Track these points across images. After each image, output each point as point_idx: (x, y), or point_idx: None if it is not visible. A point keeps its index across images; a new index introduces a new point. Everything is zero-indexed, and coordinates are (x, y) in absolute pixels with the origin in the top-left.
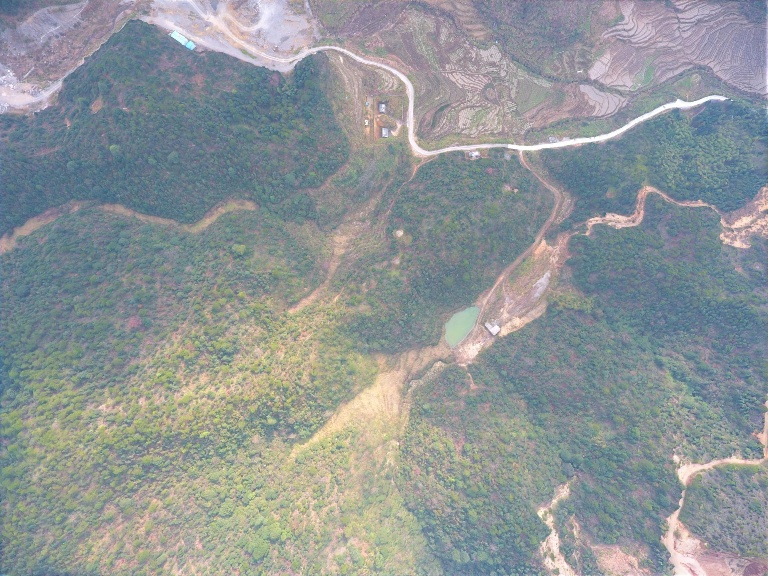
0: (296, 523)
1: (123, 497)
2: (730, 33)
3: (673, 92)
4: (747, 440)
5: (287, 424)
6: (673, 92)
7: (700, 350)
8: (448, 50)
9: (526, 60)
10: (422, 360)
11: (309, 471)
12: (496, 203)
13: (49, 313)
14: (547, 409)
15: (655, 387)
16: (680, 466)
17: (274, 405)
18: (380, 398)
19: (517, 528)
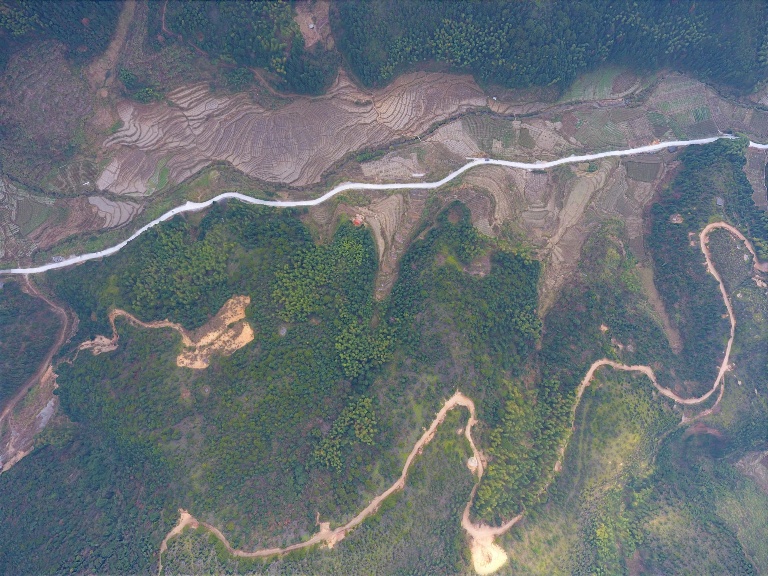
0: None
1: None
2: (247, 124)
3: (182, 195)
4: None
5: None
6: (182, 195)
7: (135, 488)
8: None
9: (23, 180)
10: None
11: None
12: None
13: None
14: (7, 559)
15: (78, 536)
16: None
17: None
18: None
19: None
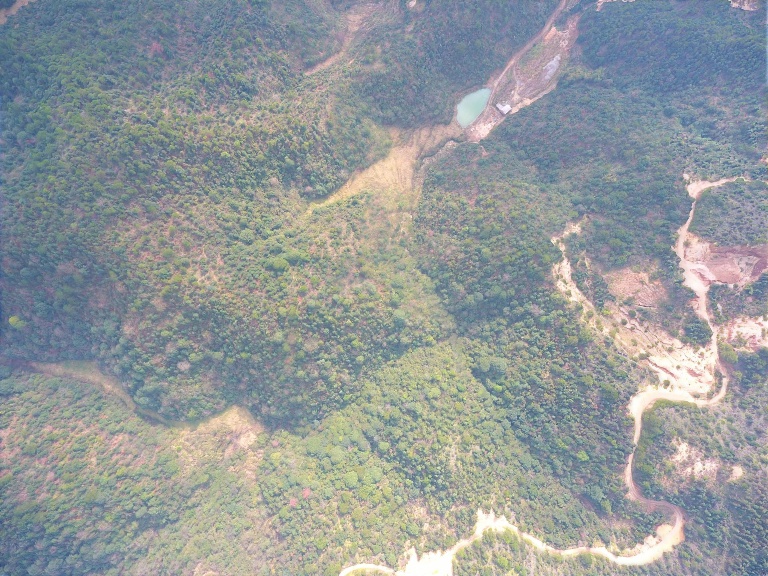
0: (314, 249)
1: (148, 200)
2: None
3: None
4: (755, 165)
5: (304, 173)
6: None
7: (709, 98)
8: None
9: None
10: (434, 138)
11: (326, 218)
12: None
13: (74, 34)
14: (558, 165)
15: (665, 128)
16: (690, 183)
17: (292, 143)
18: (394, 171)
19: (530, 250)
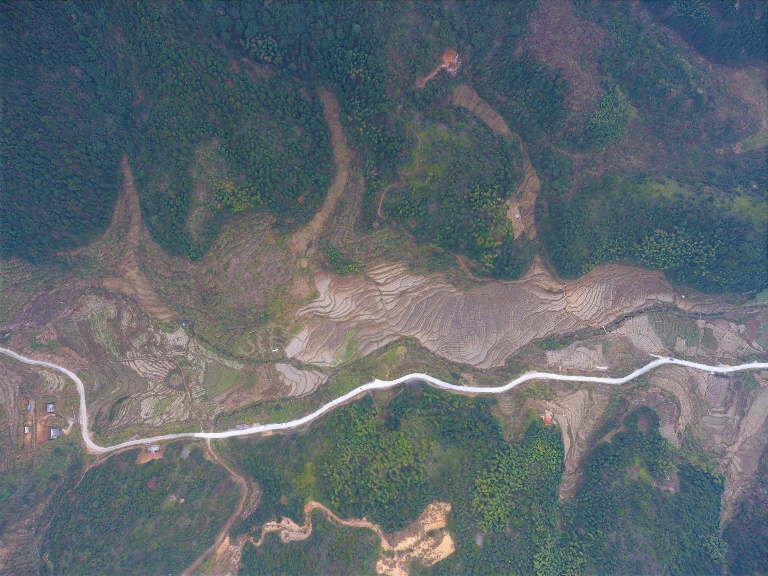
0: None
1: None
2: (438, 302)
3: (371, 371)
4: None
5: None
6: (371, 371)
7: None
8: (130, 336)
9: (214, 343)
10: None
11: None
12: (149, 526)
13: None
14: None
15: None
16: None
17: None
18: None
19: None
